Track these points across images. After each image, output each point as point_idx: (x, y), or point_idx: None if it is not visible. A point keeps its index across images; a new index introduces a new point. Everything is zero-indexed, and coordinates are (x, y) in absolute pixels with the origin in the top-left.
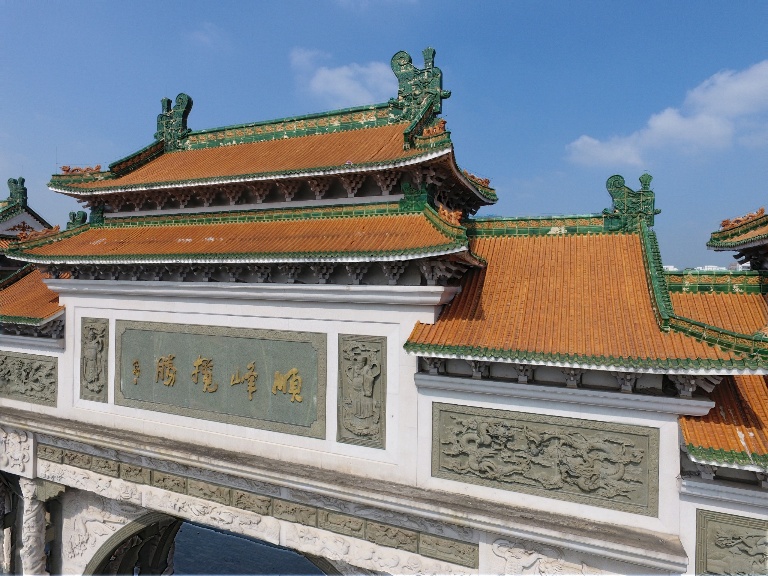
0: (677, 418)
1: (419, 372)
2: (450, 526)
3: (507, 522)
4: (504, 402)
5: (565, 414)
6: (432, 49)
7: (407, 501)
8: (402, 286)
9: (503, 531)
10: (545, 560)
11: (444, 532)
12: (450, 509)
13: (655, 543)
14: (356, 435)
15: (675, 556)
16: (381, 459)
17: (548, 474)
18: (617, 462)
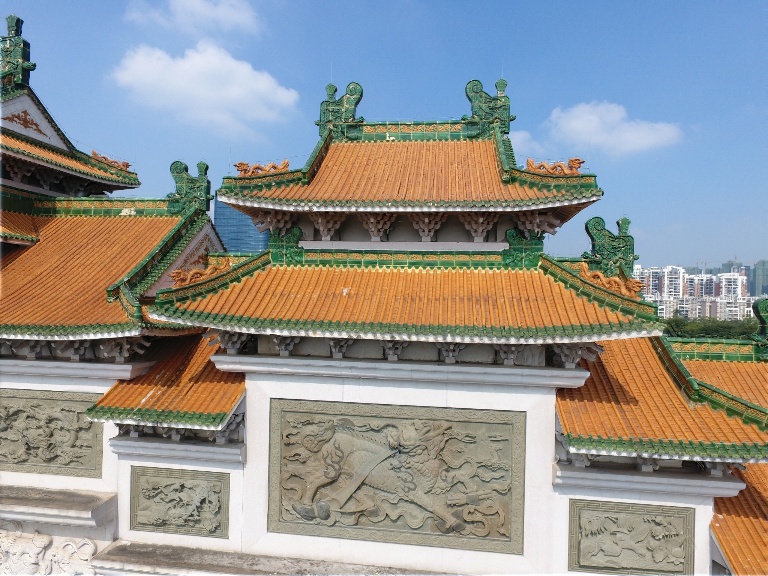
0: None
1: None
2: None
3: None
4: None
5: (29, 387)
6: (15, 17)
7: None
8: None
9: None
10: (4, 534)
11: None
12: None
13: (83, 502)
14: None
15: (81, 511)
16: None
17: (16, 448)
18: (69, 429)
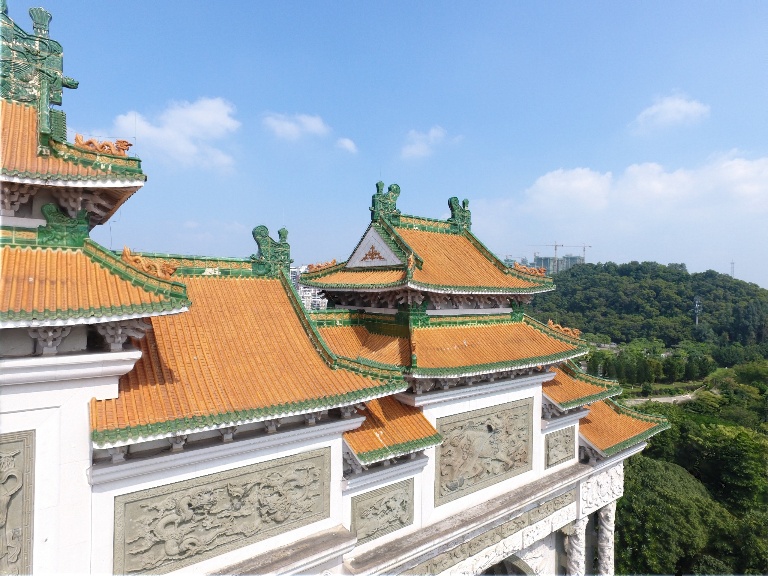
0: (342, 434)
1: (93, 465)
2: None
3: None
4: (207, 467)
5: (265, 459)
6: (48, 14)
7: None
8: (75, 356)
9: None
10: None
11: None
12: None
13: (333, 538)
14: None
15: (350, 541)
16: None
17: (249, 522)
18: (304, 485)
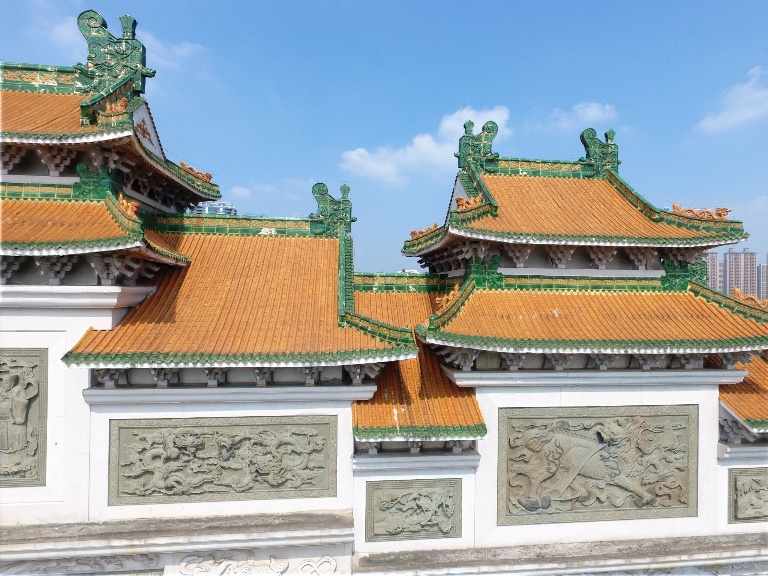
0: (351, 404)
1: (92, 387)
2: (131, 557)
3: (190, 537)
4: (193, 409)
5: (255, 413)
6: None
7: (68, 543)
8: (65, 286)
9: (187, 548)
10: (235, 565)
11: (124, 566)
12: (124, 539)
13: (331, 521)
14: (2, 475)
15: (344, 529)
16: (39, 499)
17: (239, 477)
18: (302, 452)
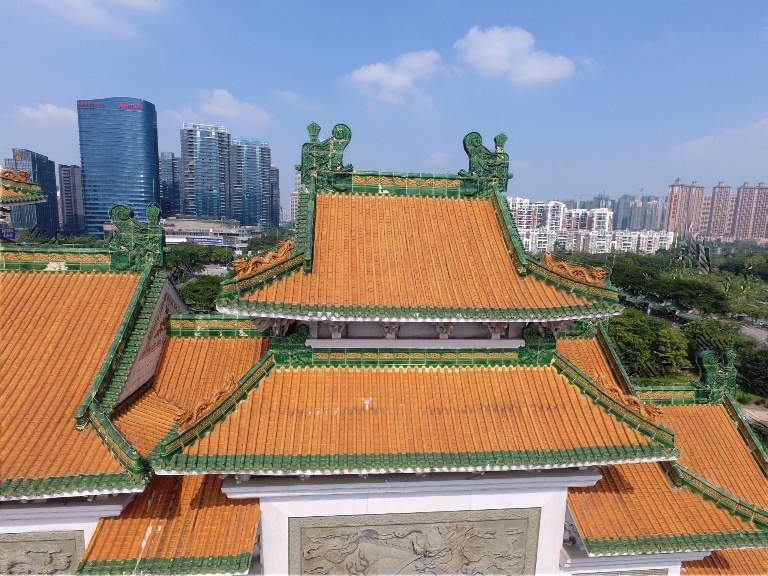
0: (99, 518)
1: None
2: None
3: None
4: None
5: None
6: None
7: None
8: None
9: None
10: None
11: None
12: None
13: None
14: None
15: None
16: None
17: None
18: (41, 573)
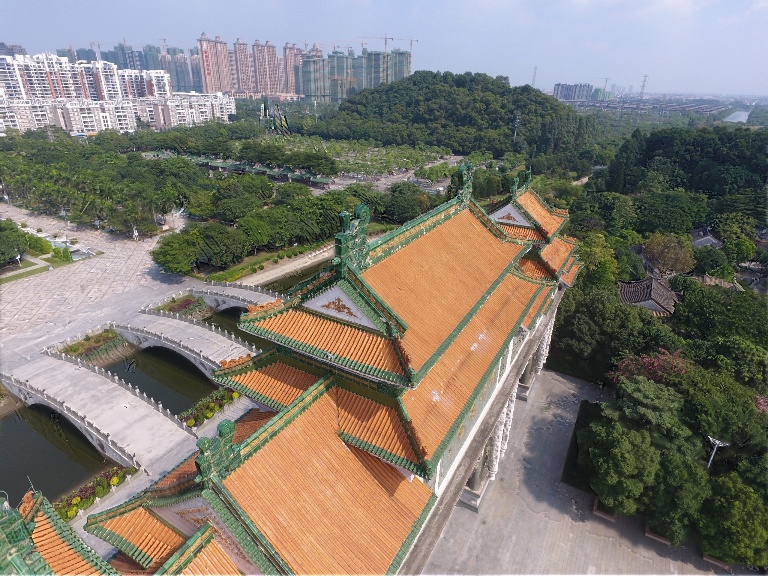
0: None
1: None
2: None
3: None
4: None
5: None
6: None
7: None
8: None
9: None
10: None
11: None
12: None
13: None
14: None
15: None
16: None
17: None
18: None
